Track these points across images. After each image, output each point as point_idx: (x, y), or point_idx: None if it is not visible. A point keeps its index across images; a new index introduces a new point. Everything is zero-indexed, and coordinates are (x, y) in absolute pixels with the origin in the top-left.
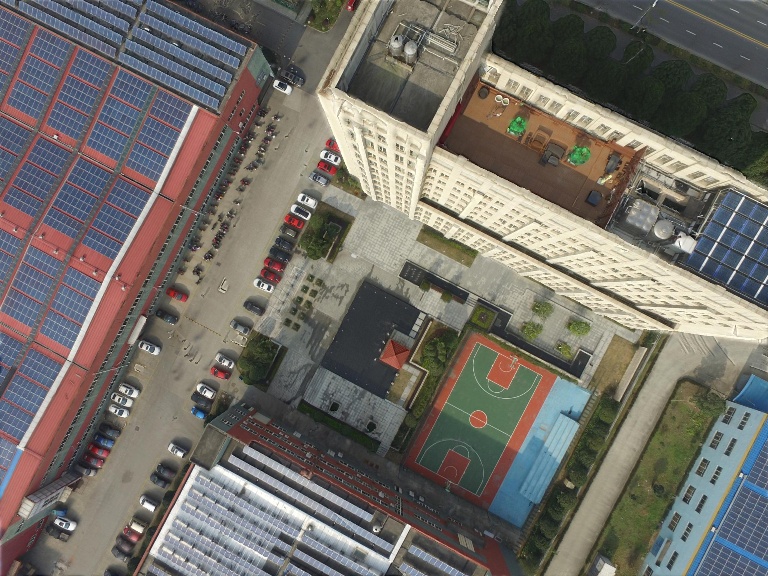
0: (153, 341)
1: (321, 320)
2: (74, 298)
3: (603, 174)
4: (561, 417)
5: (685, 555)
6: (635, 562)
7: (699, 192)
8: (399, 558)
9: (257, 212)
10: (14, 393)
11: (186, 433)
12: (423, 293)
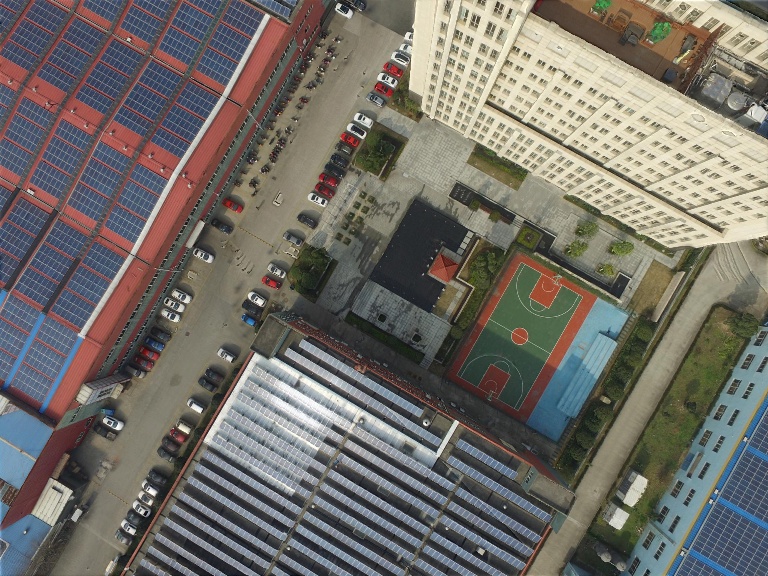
0: (207, 250)
1: (371, 236)
2: (140, 194)
3: (678, 55)
4: (600, 336)
5: (718, 463)
6: (665, 478)
7: (766, 75)
8: (446, 453)
9: (314, 130)
10: (77, 283)
11: (235, 340)
12: (472, 213)
